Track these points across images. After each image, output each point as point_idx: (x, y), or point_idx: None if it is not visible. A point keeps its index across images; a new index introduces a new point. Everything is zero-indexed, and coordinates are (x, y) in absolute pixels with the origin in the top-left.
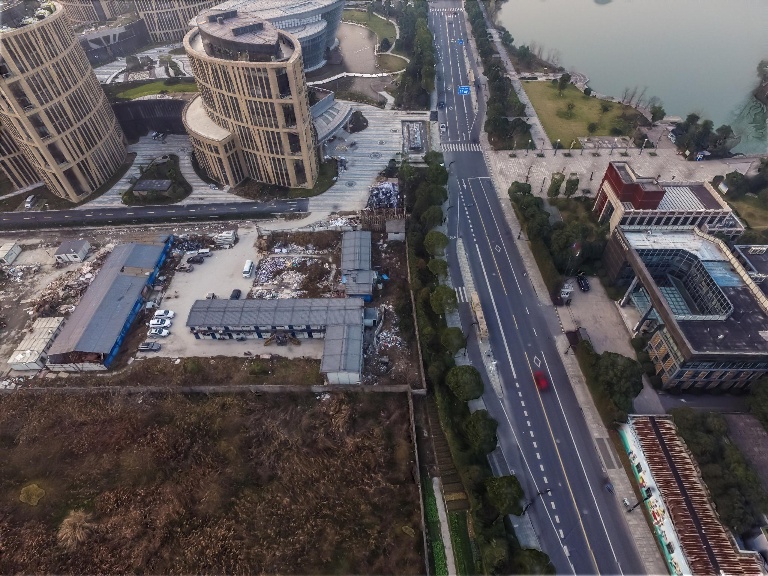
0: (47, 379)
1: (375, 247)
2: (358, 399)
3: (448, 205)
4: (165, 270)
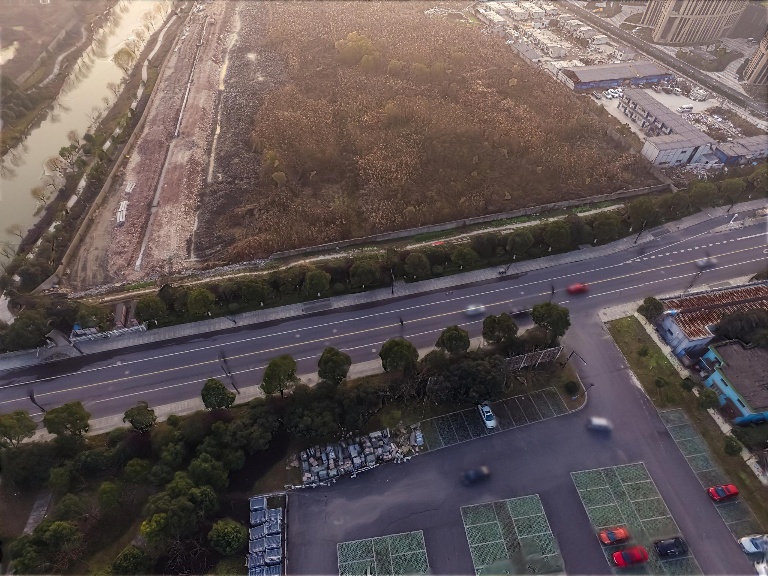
0: (553, 78)
1: None
2: (642, 170)
3: None
4: (647, 85)
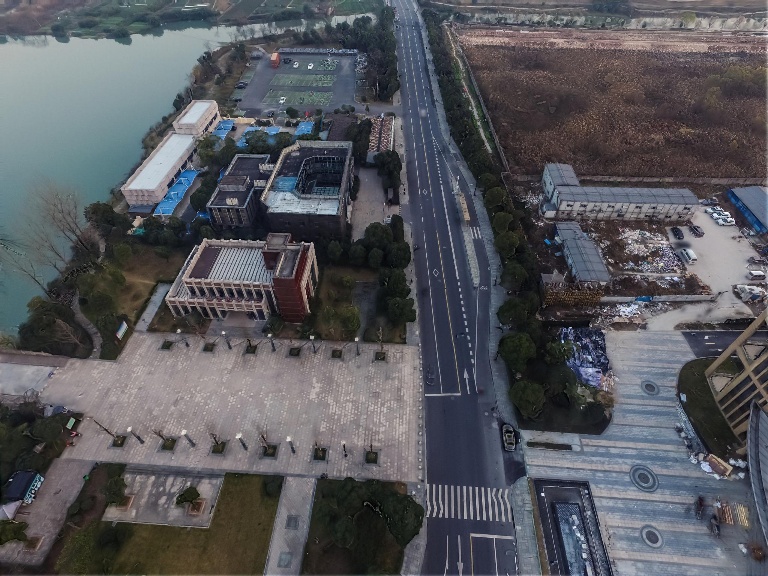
0: None
1: (569, 280)
2: None
3: (491, 336)
4: None
